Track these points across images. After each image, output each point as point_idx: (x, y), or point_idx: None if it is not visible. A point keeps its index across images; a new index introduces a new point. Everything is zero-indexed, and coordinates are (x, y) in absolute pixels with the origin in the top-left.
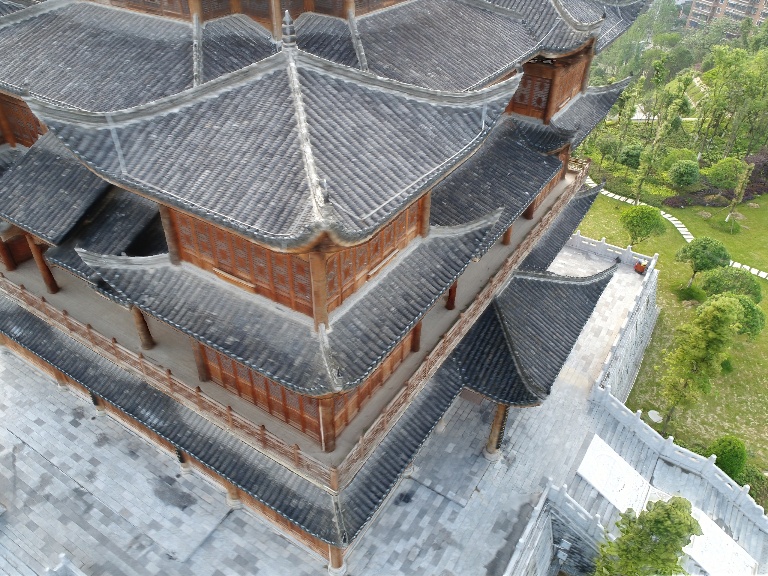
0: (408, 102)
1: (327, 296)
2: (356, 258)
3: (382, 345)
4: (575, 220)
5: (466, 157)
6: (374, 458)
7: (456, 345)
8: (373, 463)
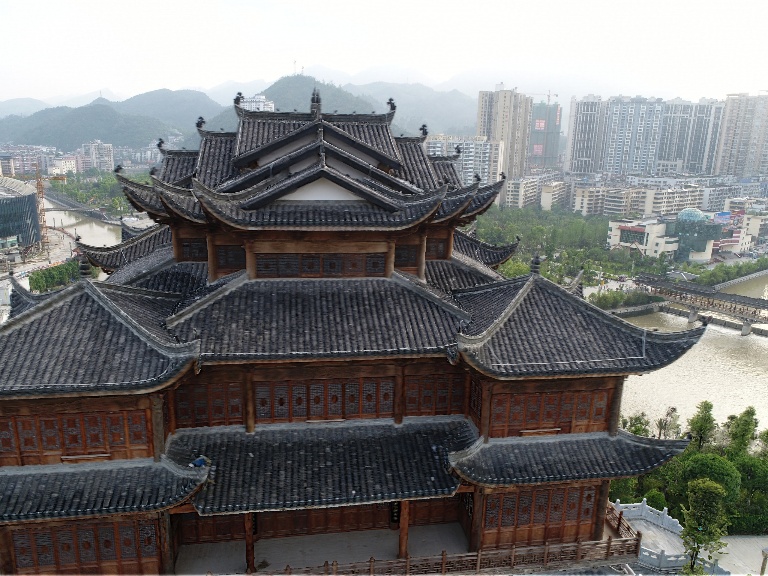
0: (130, 336)
1: (1, 449)
2: (43, 435)
3: (8, 511)
4: None
5: (125, 391)
6: None
7: None
8: None
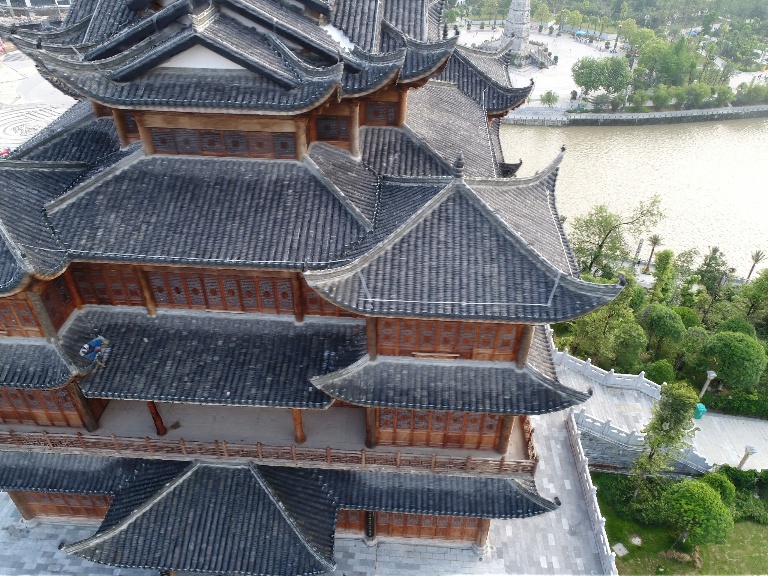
0: None
1: None
2: None
3: None
4: (482, 508)
5: None
6: (7, 462)
7: (112, 456)
8: (2, 464)
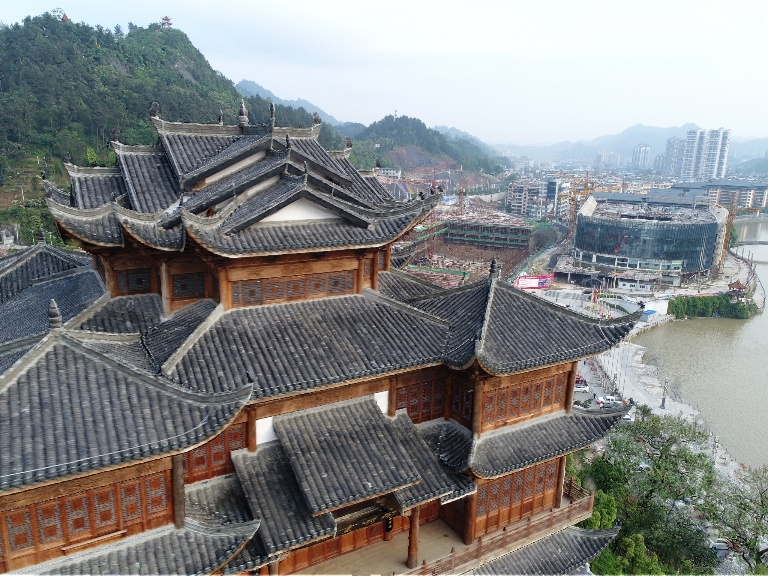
0: None
1: None
2: None
3: None
4: None
5: None
6: None
7: None
8: None
